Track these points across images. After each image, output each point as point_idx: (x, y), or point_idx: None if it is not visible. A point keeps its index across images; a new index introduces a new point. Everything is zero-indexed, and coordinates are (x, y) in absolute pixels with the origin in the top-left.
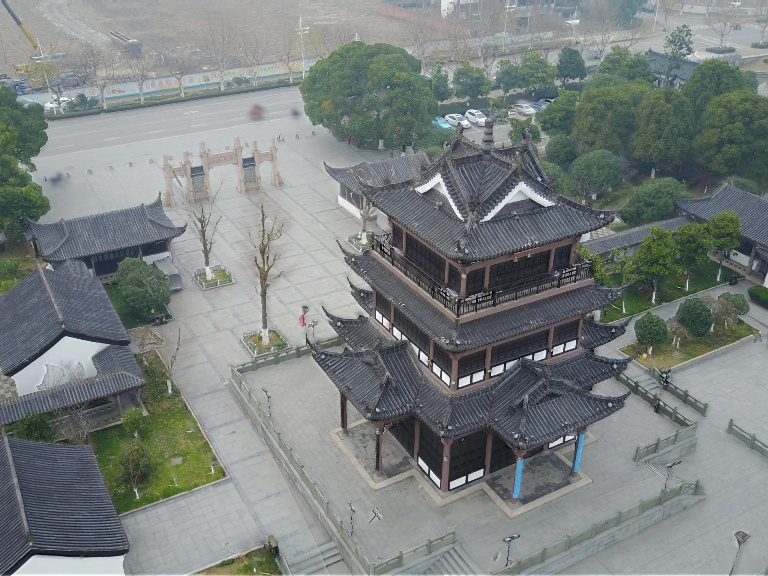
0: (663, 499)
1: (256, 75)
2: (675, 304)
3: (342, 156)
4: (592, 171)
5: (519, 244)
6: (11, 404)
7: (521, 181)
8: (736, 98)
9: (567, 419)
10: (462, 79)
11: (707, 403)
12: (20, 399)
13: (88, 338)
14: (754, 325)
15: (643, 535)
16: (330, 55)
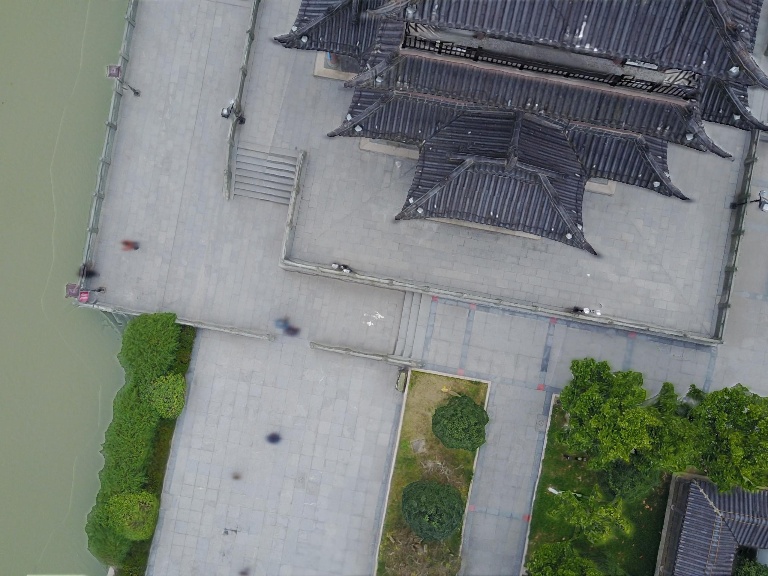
0: None
1: None
2: None
3: None
4: None
5: None
6: None
7: None
8: None
9: None
10: None
11: None
12: None
13: None
14: None
15: None
16: None
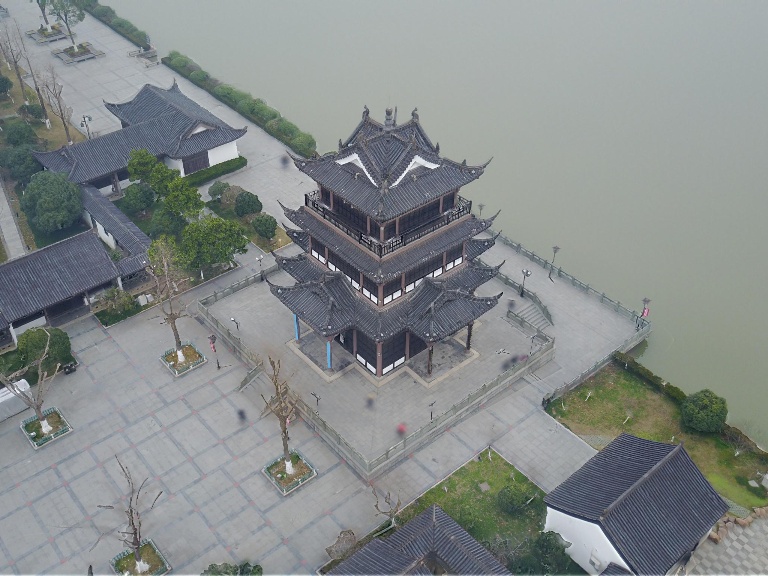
0: None
1: None
2: None
3: None
4: None
5: None
6: None
7: None
8: None
9: None
10: None
11: None
12: None
13: None
14: None
15: None
16: None
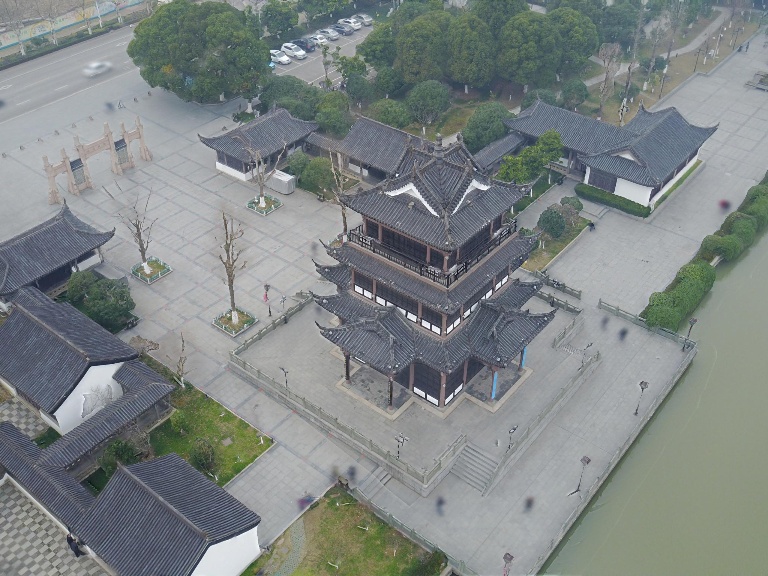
0: (583, 371)
1: (54, 33)
2: (527, 211)
3: (191, 115)
4: (427, 101)
5: (480, 226)
6: (77, 438)
7: (473, 179)
8: (525, 20)
9: (522, 337)
10: (270, 14)
11: (579, 289)
12: (82, 431)
13: (108, 362)
14: (586, 216)
15: (575, 398)
16: (157, 18)
